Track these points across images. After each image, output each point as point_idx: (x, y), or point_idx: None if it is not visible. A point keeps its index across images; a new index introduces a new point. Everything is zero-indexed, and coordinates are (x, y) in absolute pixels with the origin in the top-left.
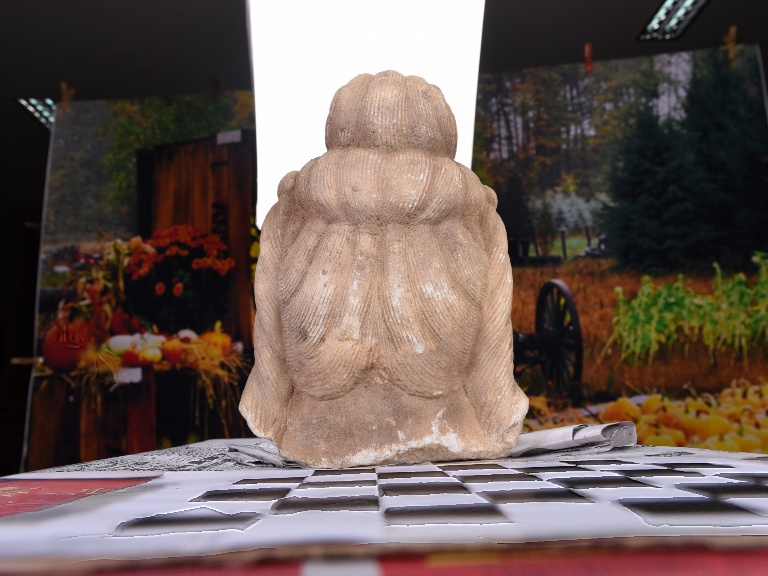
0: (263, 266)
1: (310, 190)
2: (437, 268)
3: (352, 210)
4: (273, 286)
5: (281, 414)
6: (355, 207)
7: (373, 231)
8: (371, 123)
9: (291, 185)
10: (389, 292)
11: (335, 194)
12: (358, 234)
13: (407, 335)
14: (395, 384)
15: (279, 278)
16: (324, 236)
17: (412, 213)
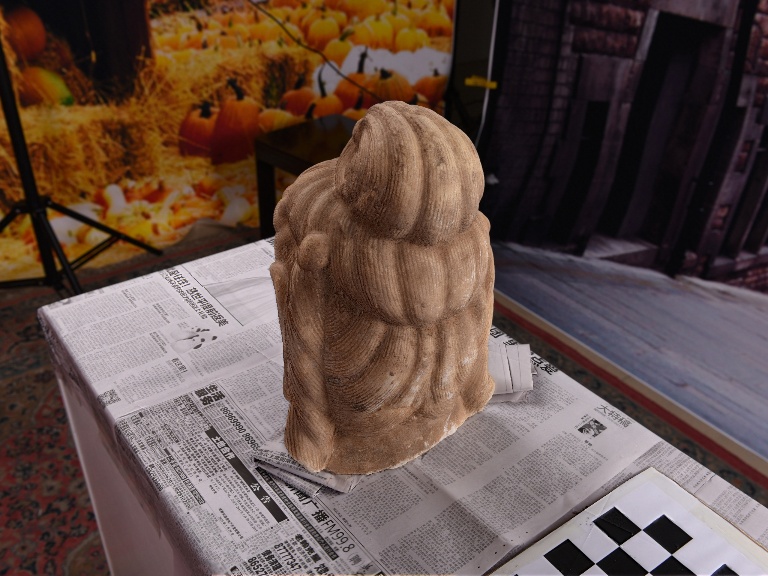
0: (305, 348)
1: (369, 295)
2: (473, 342)
3: (418, 321)
4: (319, 365)
5: (329, 450)
6: (422, 319)
7: (432, 331)
8: (433, 228)
9: (325, 264)
10: (442, 376)
11: (401, 306)
12: (420, 337)
13: (446, 393)
14: (426, 417)
15: (325, 359)
16: (386, 339)
17: (462, 308)
